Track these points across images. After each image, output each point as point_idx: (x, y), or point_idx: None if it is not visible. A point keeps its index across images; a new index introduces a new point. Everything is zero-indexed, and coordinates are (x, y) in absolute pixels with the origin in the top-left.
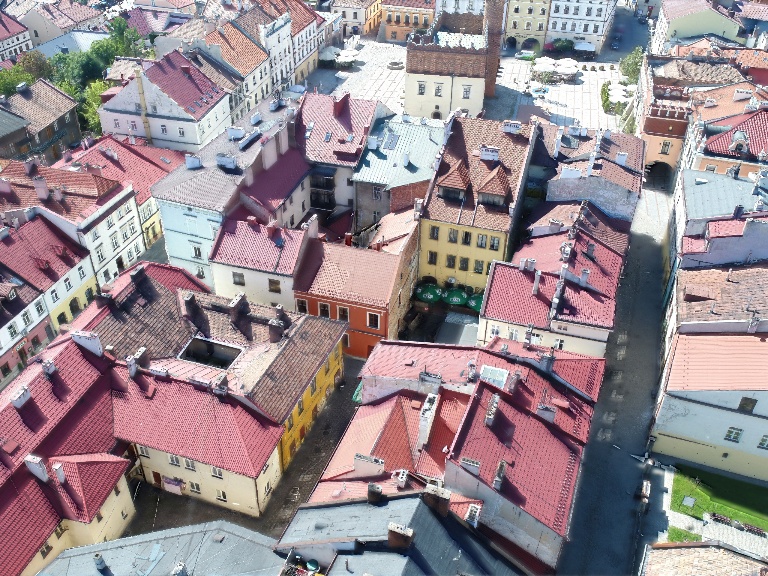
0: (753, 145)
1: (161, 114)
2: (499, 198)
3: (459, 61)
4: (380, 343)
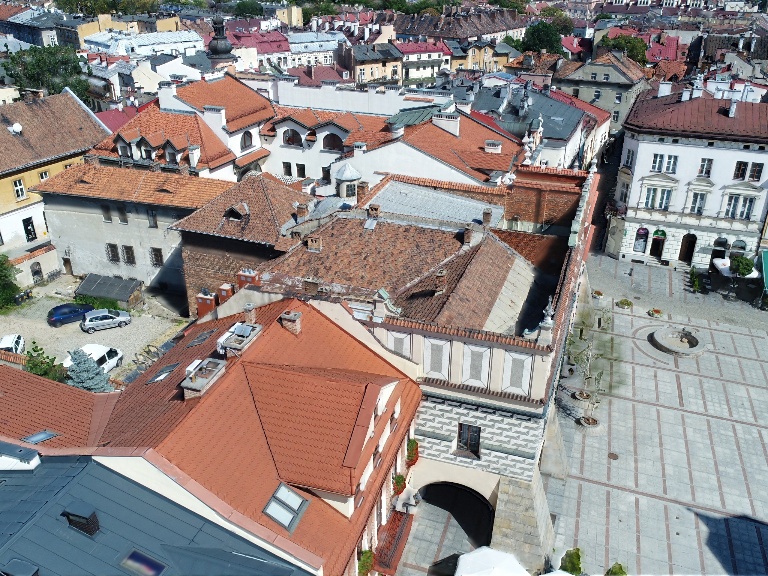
0: None
1: None
2: None
3: None
4: None
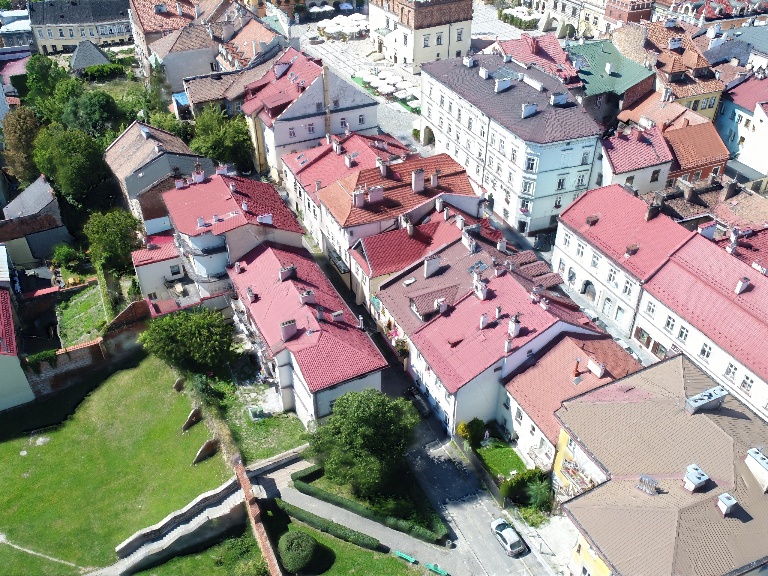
0: (724, 8)
1: (343, 107)
2: (705, 70)
3: (454, 9)
4: None
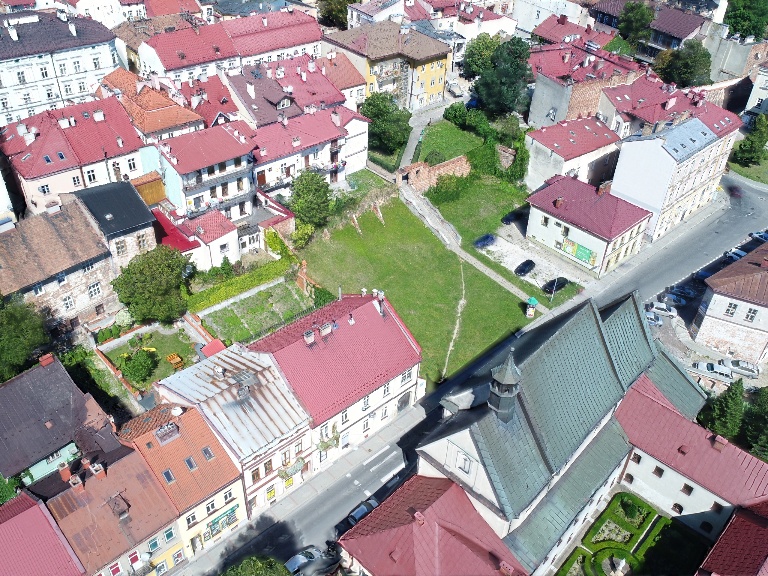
0: None
1: None
2: None
3: None
4: (122, 3)
